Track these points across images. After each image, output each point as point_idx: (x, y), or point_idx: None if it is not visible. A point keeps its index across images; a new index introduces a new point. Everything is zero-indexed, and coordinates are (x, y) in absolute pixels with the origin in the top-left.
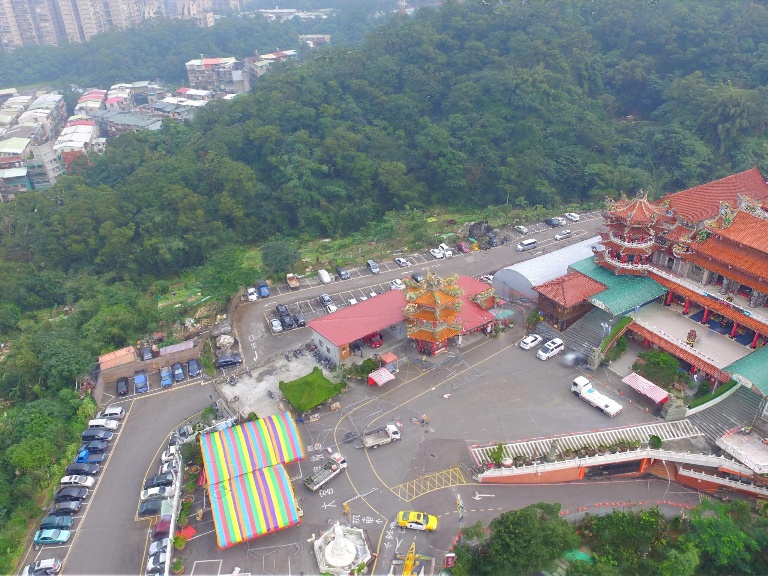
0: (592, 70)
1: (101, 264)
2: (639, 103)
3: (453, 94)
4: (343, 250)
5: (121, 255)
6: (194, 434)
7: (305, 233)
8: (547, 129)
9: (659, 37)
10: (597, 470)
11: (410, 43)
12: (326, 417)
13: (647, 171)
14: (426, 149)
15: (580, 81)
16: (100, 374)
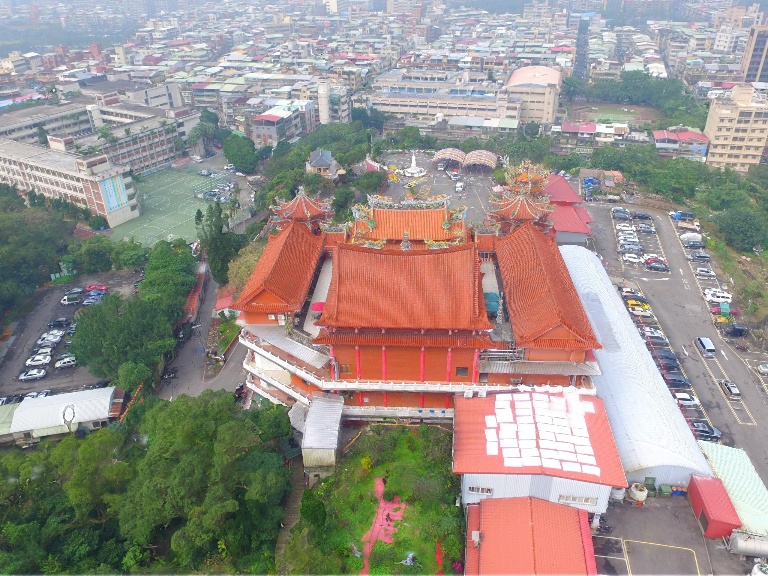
0: None
1: None
2: None
3: None
4: None
5: None
6: None
7: None
8: None
9: None
10: None
11: None
12: None
13: None
14: None
15: None
16: None
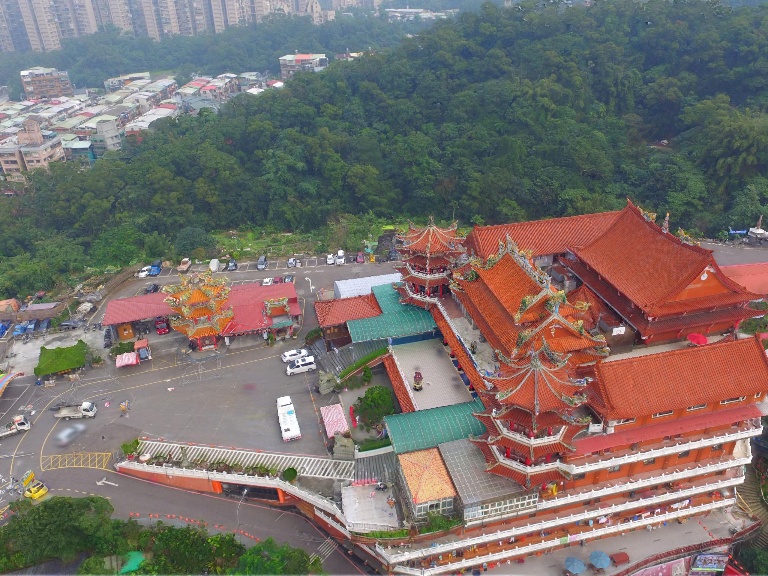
0: (622, 86)
1: (81, 229)
2: (672, 127)
3: (451, 102)
4: (286, 245)
5: (97, 223)
6: None
7: (271, 225)
8: (533, 146)
9: (703, 53)
10: (237, 488)
11: (436, 48)
12: (60, 385)
13: None
14: (401, 156)
15: (607, 97)
16: None
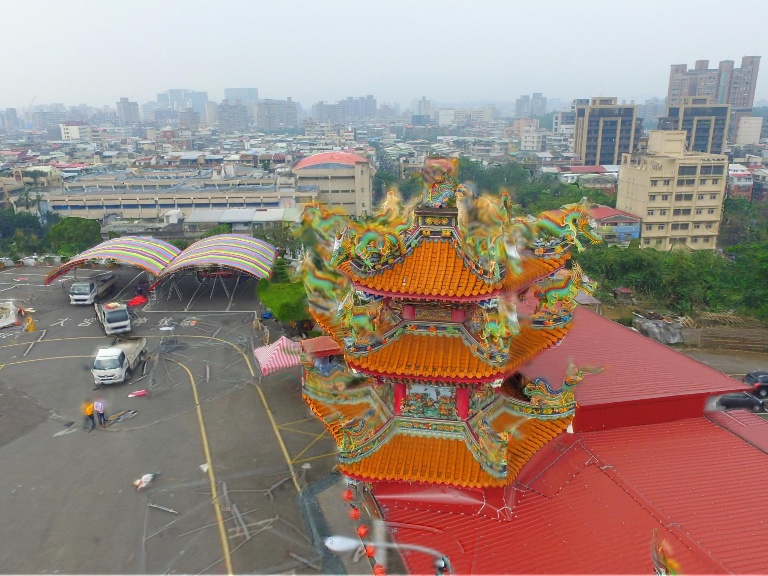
0: None
1: None
2: None
3: None
4: None
5: None
6: None
7: None
8: None
9: None
10: None
11: None
12: None
13: None
14: None
15: None
16: None
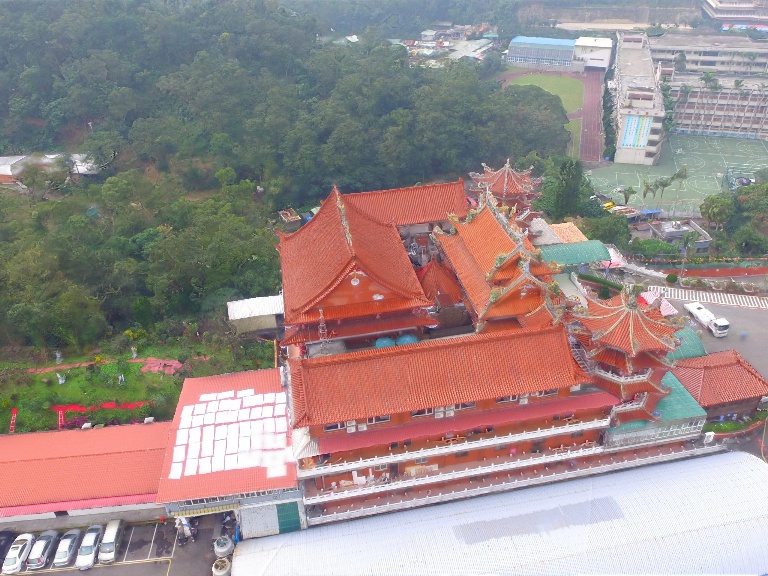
0: None
1: None
2: None
3: None
4: None
5: None
6: None
7: None
8: None
9: None
10: None
11: None
12: None
13: None
14: None
15: None
16: None
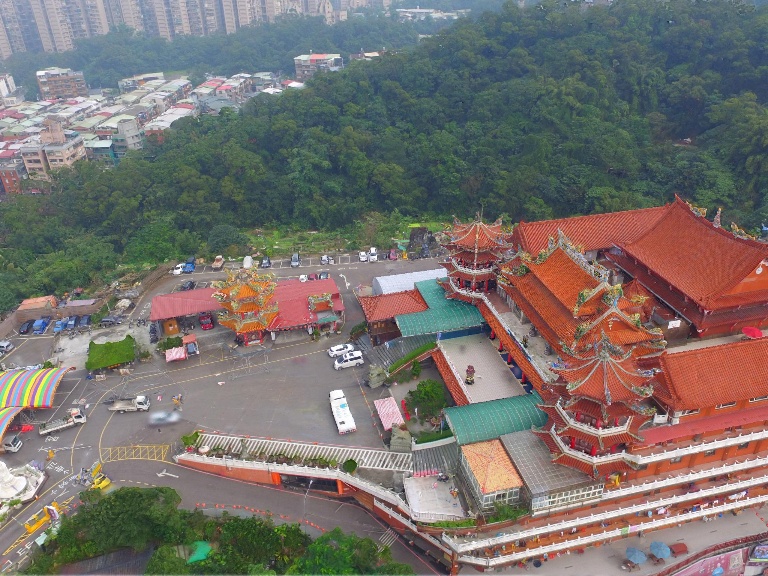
0: (645, 85)
1: (109, 227)
2: (696, 125)
3: (475, 101)
4: (314, 243)
5: (125, 221)
6: (5, 370)
7: (297, 223)
8: (559, 145)
9: (728, 51)
10: (295, 480)
11: (458, 47)
12: (111, 379)
13: (659, 201)
14: (426, 154)
15: (630, 96)
16: (13, 313)
